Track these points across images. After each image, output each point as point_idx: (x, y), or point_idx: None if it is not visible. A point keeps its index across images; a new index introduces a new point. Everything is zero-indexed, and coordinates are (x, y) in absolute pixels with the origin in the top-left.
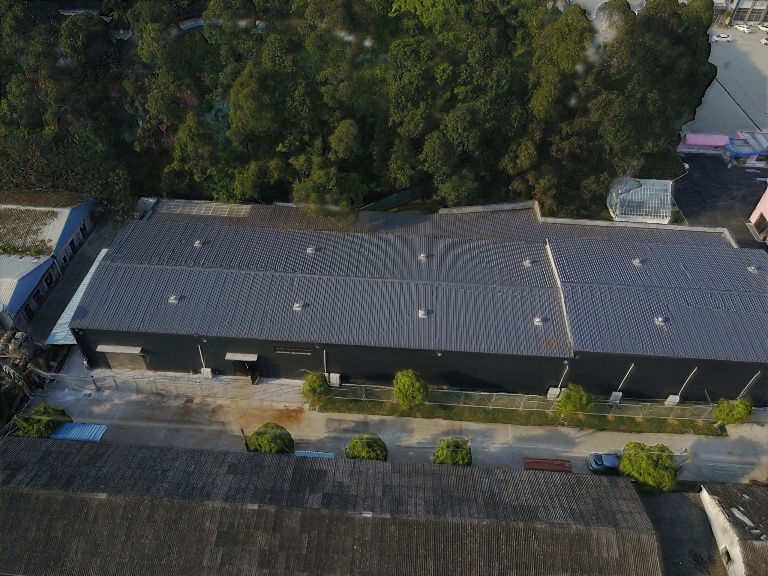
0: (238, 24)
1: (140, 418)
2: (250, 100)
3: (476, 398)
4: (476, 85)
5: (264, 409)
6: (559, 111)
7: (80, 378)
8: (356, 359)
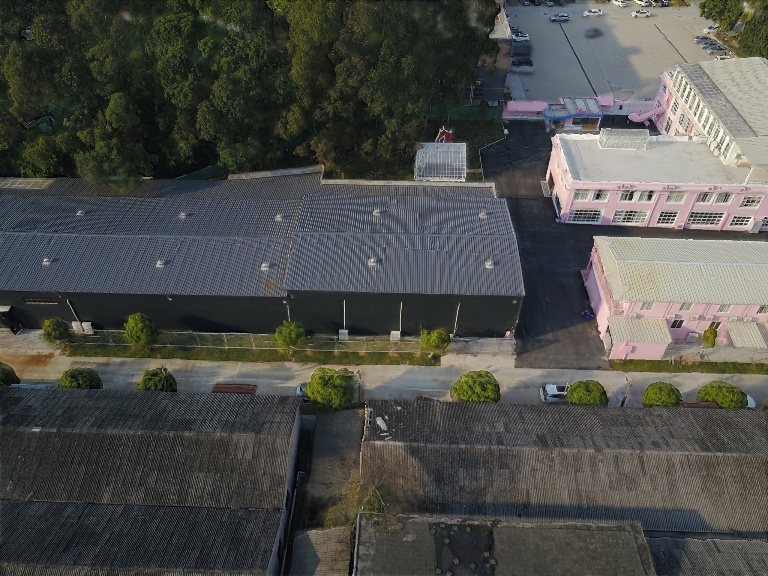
0: (2, 7)
1: None
2: (16, 77)
3: (210, 339)
4: (238, 56)
5: (18, 355)
6: (326, 78)
7: None
8: (100, 307)
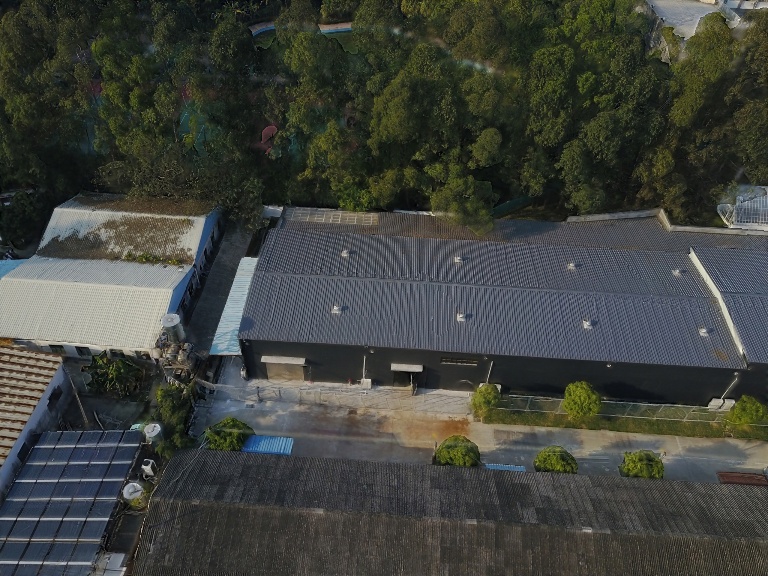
0: (389, 33)
1: (308, 429)
2: (401, 109)
3: (642, 409)
4: (617, 94)
5: (429, 420)
6: (694, 119)
7: (239, 389)
8: (521, 370)
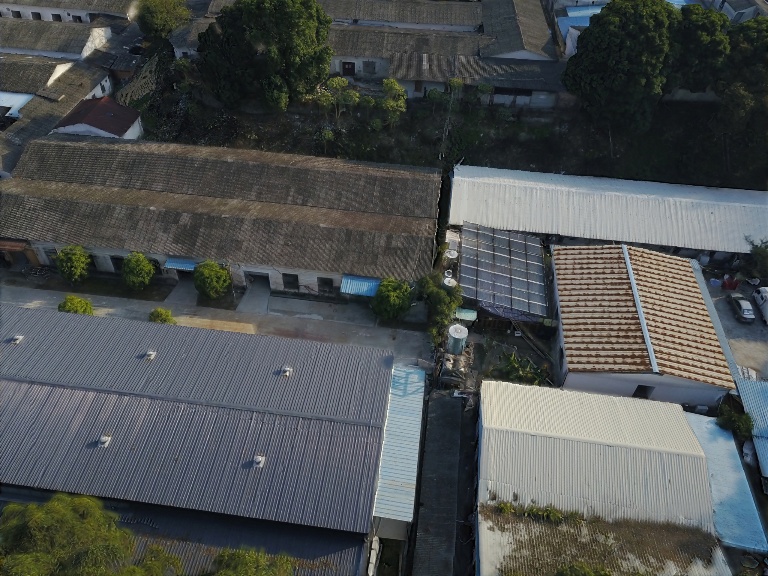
0: None
1: (330, 342)
2: None
3: None
4: None
5: None
6: None
7: None
8: None
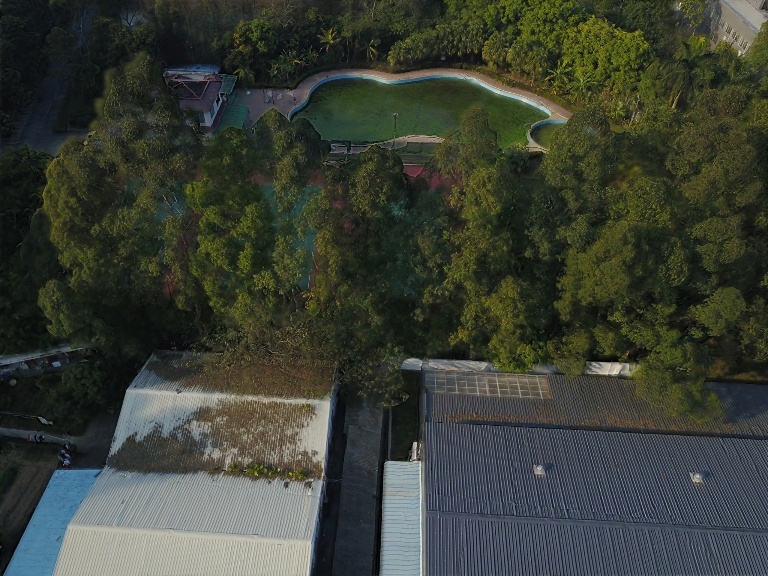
0: (604, 168)
1: None
2: (621, 274)
3: None
4: None
5: None
6: None
7: None
8: None
